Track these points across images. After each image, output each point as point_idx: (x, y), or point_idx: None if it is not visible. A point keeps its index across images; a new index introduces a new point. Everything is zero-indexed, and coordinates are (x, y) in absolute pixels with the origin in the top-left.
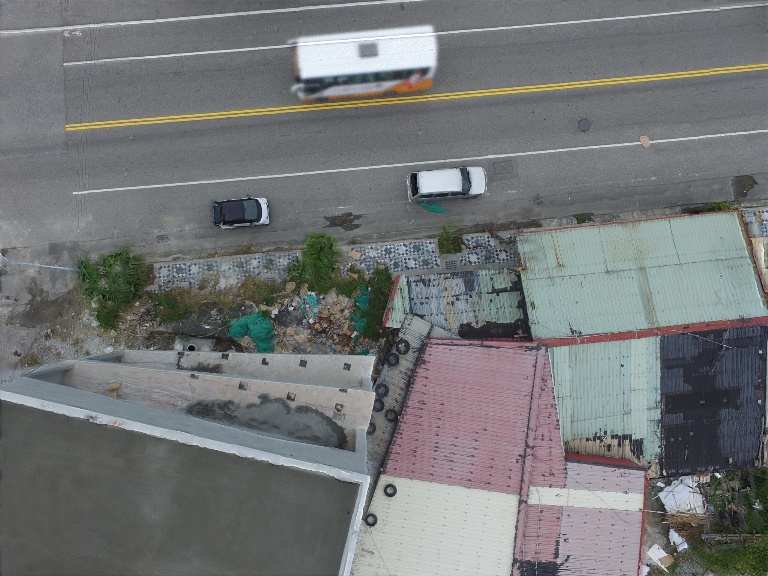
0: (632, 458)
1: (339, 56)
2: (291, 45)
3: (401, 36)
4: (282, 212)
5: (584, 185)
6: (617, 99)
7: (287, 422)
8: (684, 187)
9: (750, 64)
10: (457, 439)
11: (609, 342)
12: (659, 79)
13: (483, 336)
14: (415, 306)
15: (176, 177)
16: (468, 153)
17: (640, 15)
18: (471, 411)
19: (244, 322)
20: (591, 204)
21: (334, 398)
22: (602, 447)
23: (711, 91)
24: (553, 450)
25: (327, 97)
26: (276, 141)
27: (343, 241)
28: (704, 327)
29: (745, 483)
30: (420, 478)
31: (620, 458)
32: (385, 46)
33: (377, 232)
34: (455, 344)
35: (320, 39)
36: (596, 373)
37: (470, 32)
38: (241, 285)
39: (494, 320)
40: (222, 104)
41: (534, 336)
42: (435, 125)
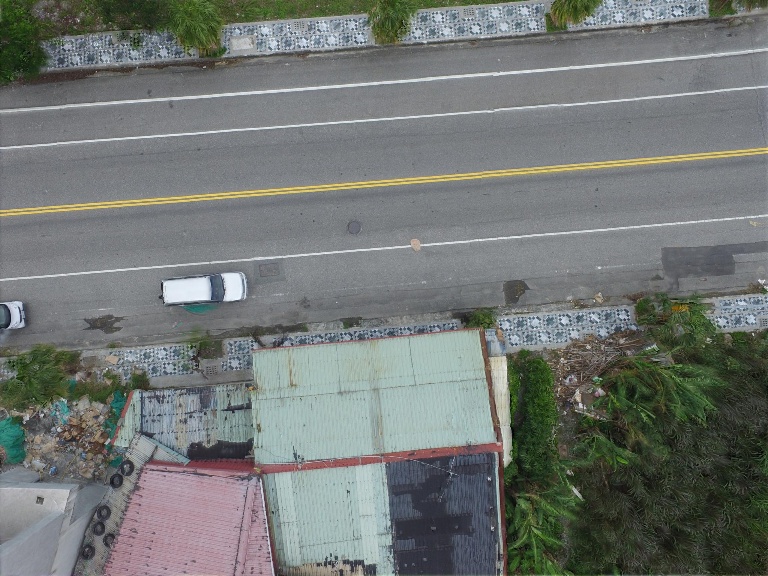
0: None
1: (104, 155)
2: (55, 143)
3: (168, 135)
4: (41, 314)
5: (352, 289)
6: (388, 201)
7: None
8: (455, 291)
9: (524, 167)
10: (166, 570)
11: (332, 468)
12: (430, 181)
13: (213, 456)
14: (146, 424)
15: None
16: (234, 255)
17: (413, 116)
18: (181, 541)
19: None
20: (359, 308)
21: None
22: (334, 572)
23: (483, 194)
24: None
25: (90, 197)
26: (36, 241)
27: (103, 344)
28: (429, 454)
29: None
30: None
31: None
32: (151, 145)
33: (138, 335)
34: (169, 471)
35: (85, 137)
36: (322, 498)
37: (240, 131)
38: None
39: (227, 439)
40: None
41: (256, 461)
42: (200, 226)
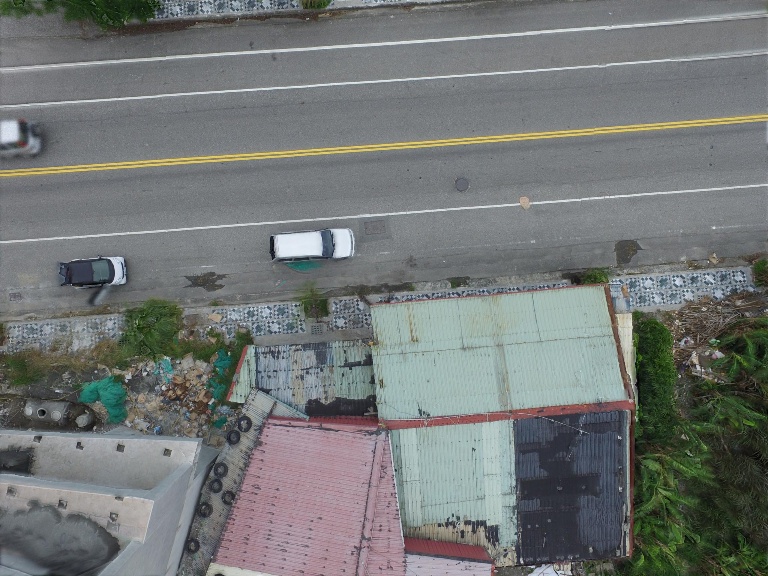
0: (487, 545)
1: (206, 108)
2: (155, 96)
3: (271, 88)
4: (141, 271)
5: (460, 247)
6: (496, 158)
7: (54, 533)
8: (565, 251)
9: (637, 123)
10: (291, 527)
11: (459, 425)
12: (541, 138)
13: (331, 413)
14: (262, 379)
15: (30, 232)
16: (339, 212)
17: (523, 70)
18: (307, 498)
19: (94, 387)
20: (467, 267)
21: (109, 507)
22: (455, 533)
23: (595, 151)
24: (392, 541)
25: (191, 151)
26: (137, 196)
27: (205, 302)
28: (559, 411)
29: (618, 566)
30: (251, 568)
31: (474, 545)
32: (254, 98)
33: (241, 293)
34: (293, 425)
35: (186, 90)
36: (446, 456)
37: (344, 85)
38: (94, 347)
39: (344, 396)
40: (81, 157)
41: (380, 417)
42: (304, 182)
